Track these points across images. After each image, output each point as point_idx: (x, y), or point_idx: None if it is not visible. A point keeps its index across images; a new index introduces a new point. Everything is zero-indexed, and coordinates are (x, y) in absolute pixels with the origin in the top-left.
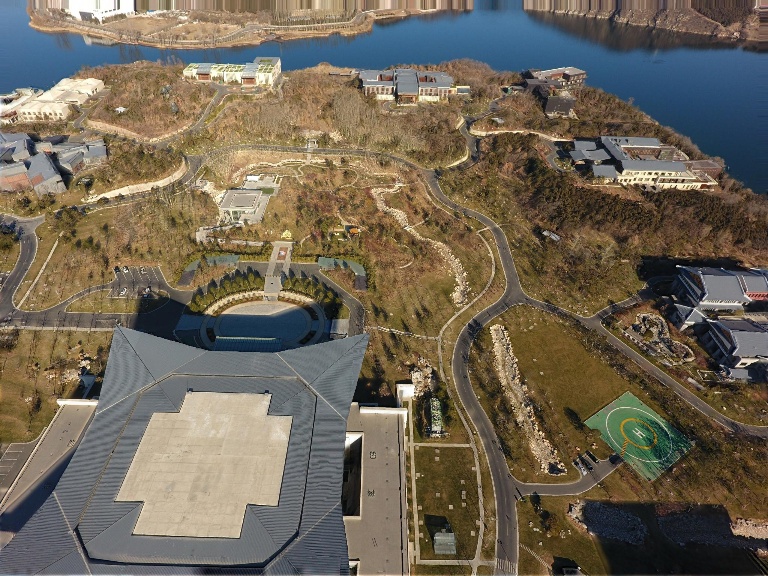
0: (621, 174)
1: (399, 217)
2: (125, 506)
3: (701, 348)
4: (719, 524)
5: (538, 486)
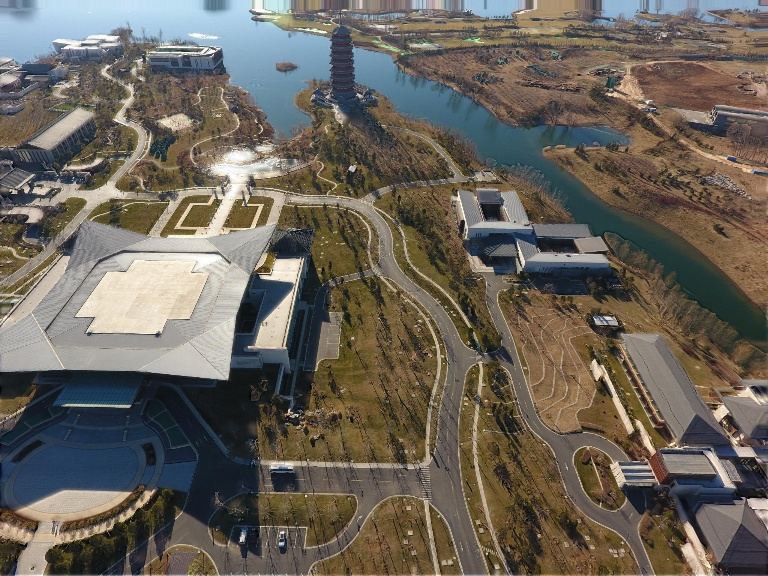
0: None
1: None
2: (203, 271)
3: None
4: None
5: None
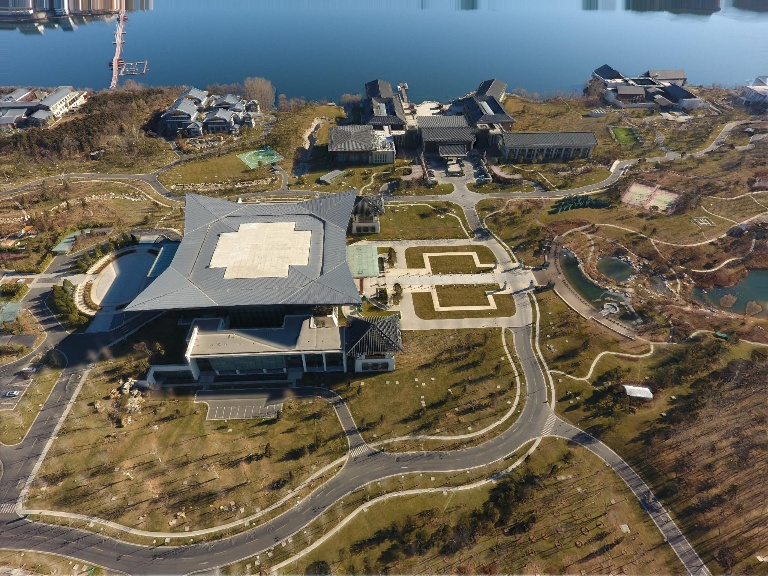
0: (51, 111)
1: (2, 223)
2: (291, 272)
3: (216, 133)
4: (304, 150)
5: (283, 184)
